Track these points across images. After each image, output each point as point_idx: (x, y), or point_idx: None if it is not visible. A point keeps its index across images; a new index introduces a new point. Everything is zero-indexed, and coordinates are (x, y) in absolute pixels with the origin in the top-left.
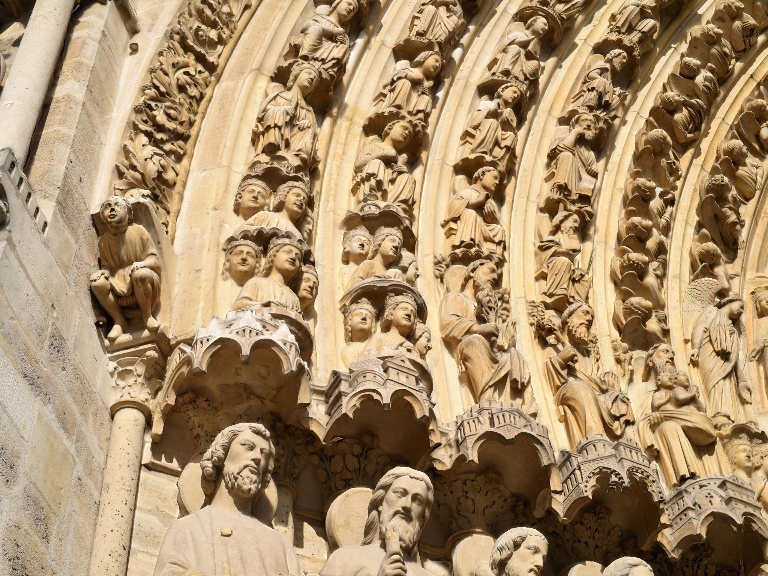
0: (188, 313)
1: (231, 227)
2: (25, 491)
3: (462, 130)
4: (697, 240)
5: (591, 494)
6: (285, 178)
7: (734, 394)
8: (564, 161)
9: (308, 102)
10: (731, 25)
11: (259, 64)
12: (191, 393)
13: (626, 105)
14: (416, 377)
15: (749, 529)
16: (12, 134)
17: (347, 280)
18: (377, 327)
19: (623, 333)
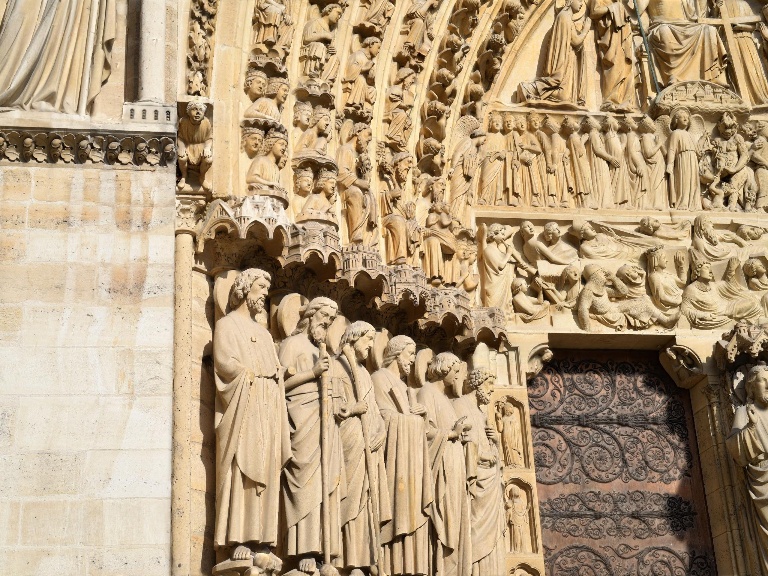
0: (223, 177)
1: (243, 105)
2: None
3: None
4: (472, 76)
5: (398, 302)
6: (278, 72)
7: None
8: (417, 27)
9: None
10: None
11: None
12: (224, 235)
13: None
14: None
15: (462, 322)
16: (161, 71)
17: (296, 142)
18: (313, 186)
19: (420, 162)
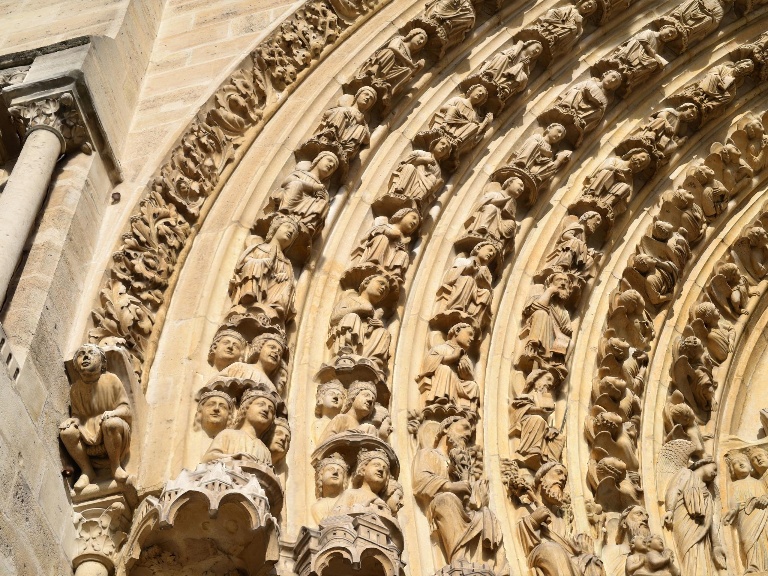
0: (157, 464)
1: (205, 377)
2: None
3: (438, 286)
4: (670, 401)
5: None
6: (261, 330)
7: (709, 559)
8: (539, 319)
9: (286, 255)
10: (702, 191)
11: (239, 216)
12: (156, 547)
13: (600, 265)
14: (387, 535)
15: None
16: None
17: (320, 434)
18: (349, 483)
19: (597, 494)
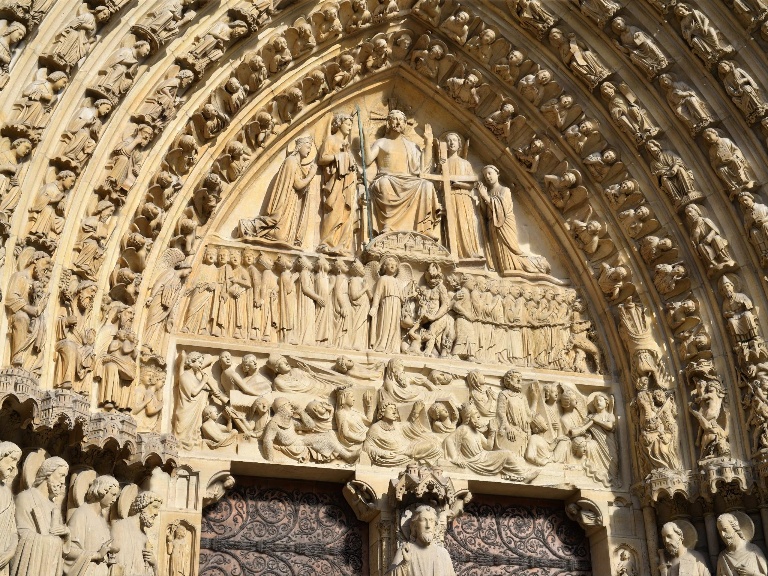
0: None
1: None
2: None
3: (65, 128)
4: (186, 211)
5: None
6: None
7: (161, 332)
8: (121, 163)
9: None
10: (274, 55)
11: None
12: None
13: (180, 106)
14: None
15: (126, 448)
16: None
17: None
18: None
19: (112, 290)
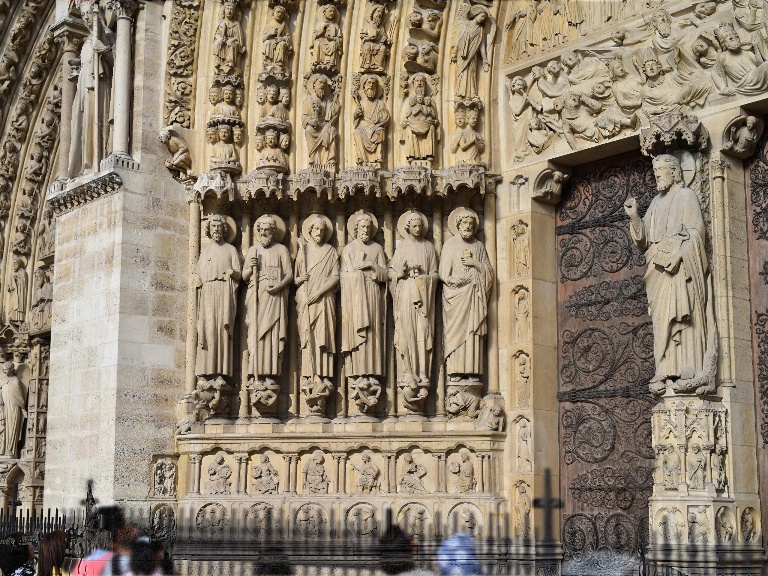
0: (199, 164)
1: (210, 112)
2: (155, 262)
3: None
4: None
5: (344, 196)
6: None
7: (469, 77)
8: None
9: (242, 4)
10: None
11: None
12: None
13: None
14: (266, 179)
15: (413, 190)
16: (119, 134)
17: None
18: None
19: (406, 68)
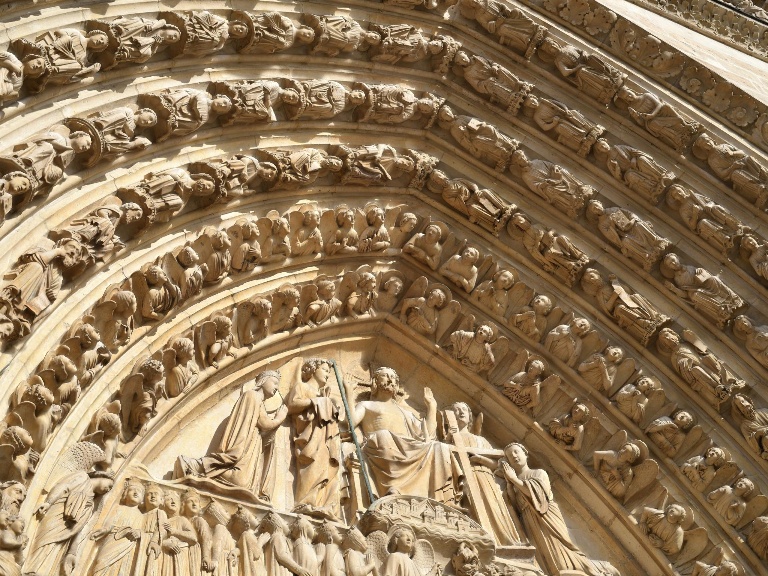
0: None
1: None
2: None
3: None
4: (107, 407)
5: None
6: None
7: (58, 562)
8: (32, 270)
9: None
10: (241, 243)
11: None
12: None
13: (116, 255)
14: None
15: None
16: None
17: None
18: None
19: None
